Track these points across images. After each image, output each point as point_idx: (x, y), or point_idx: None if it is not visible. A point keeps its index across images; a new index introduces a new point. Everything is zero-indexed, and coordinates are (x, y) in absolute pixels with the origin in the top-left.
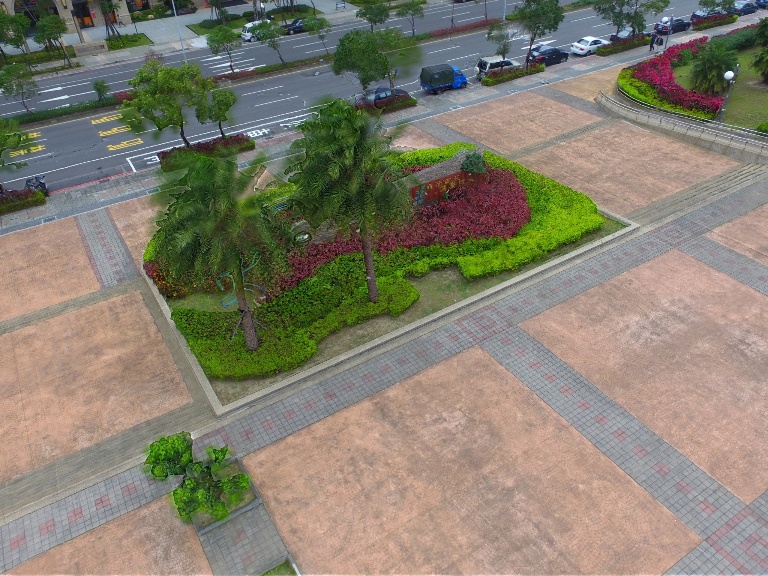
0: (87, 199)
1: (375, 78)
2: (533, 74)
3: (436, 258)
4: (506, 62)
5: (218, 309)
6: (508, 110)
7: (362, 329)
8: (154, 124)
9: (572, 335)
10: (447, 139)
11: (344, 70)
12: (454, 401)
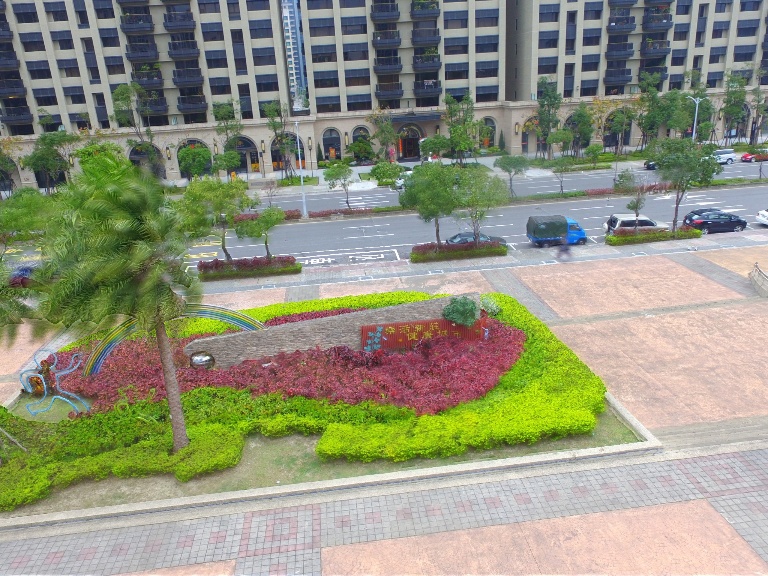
0: None
1: (436, 213)
2: (682, 239)
3: (304, 416)
4: (648, 222)
5: (45, 417)
6: (614, 272)
7: (130, 486)
8: (242, 242)
9: None
10: (507, 292)
11: (412, 203)
12: None
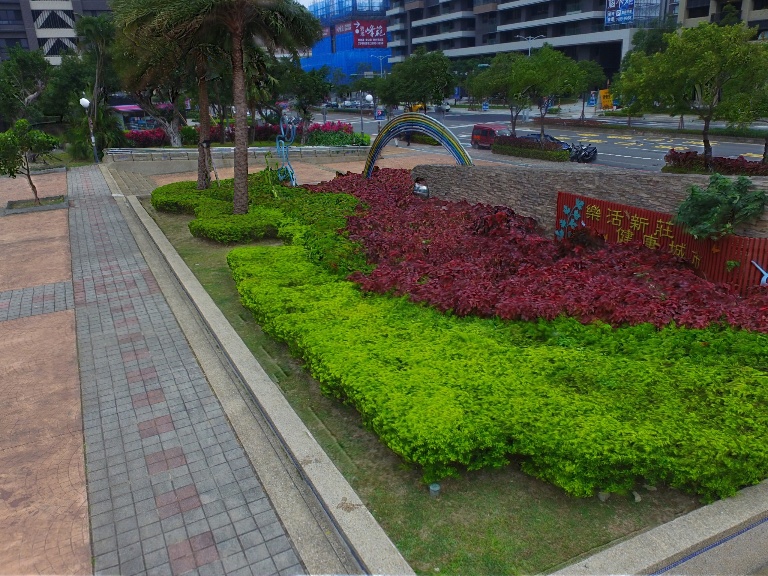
0: (572, 167)
1: None
2: None
3: None
4: None
5: None
6: None
7: None
8: None
9: None
10: None
11: None
12: None
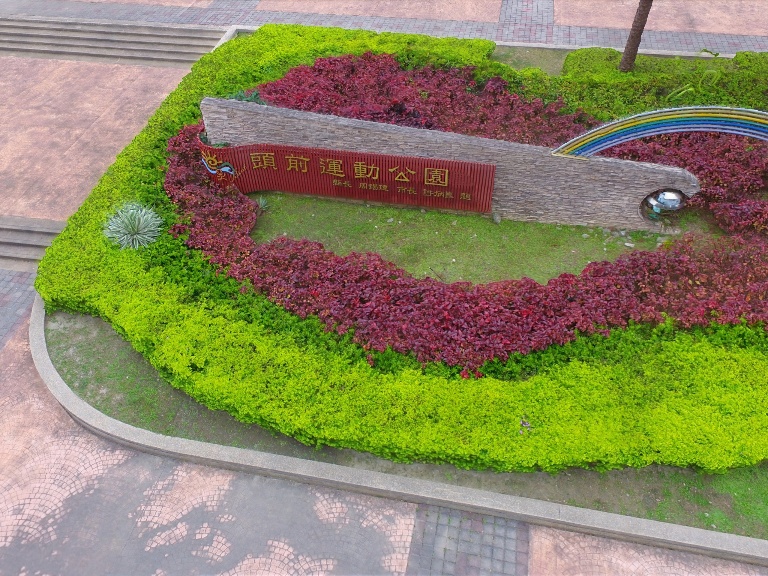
0: None
1: None
2: None
3: None
4: None
5: None
6: None
7: None
8: None
9: (468, 2)
10: None
11: None
12: (623, 8)
